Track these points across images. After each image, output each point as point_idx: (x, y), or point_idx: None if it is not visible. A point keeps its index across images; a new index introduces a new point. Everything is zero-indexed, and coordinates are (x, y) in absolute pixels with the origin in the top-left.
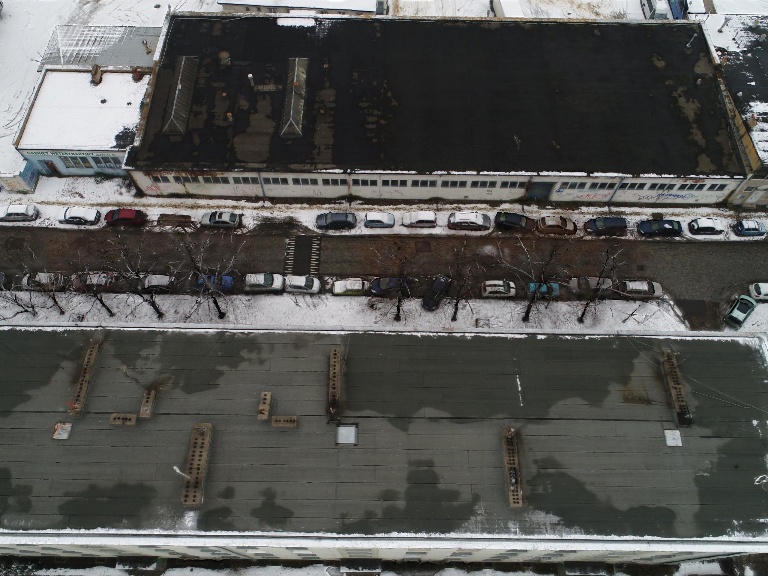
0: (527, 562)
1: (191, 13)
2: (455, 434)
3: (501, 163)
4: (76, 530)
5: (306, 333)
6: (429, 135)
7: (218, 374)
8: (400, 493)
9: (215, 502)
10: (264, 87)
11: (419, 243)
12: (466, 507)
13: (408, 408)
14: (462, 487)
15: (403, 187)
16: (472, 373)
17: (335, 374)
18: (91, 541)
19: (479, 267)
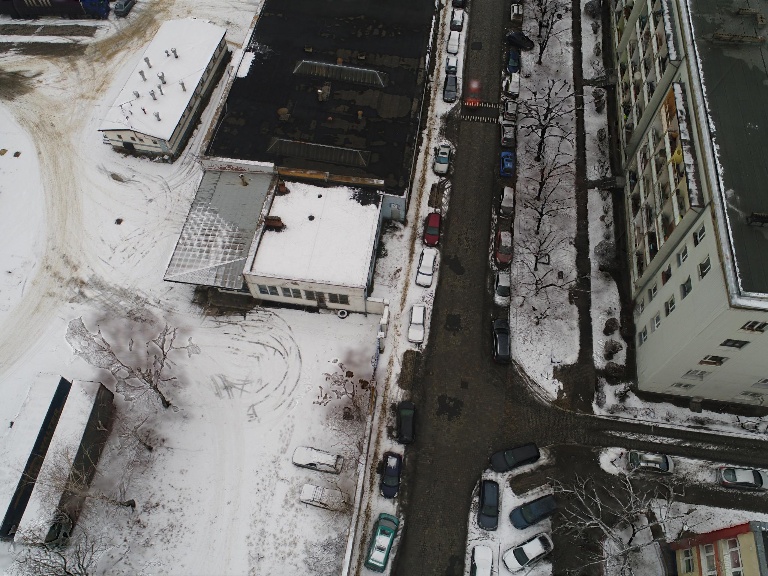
0: None
1: (207, 139)
2: None
3: None
4: None
5: None
6: (399, 4)
7: None
8: None
9: None
10: (324, 93)
11: (473, 48)
12: None
13: None
14: None
15: None
16: None
17: None
18: None
19: (496, 21)
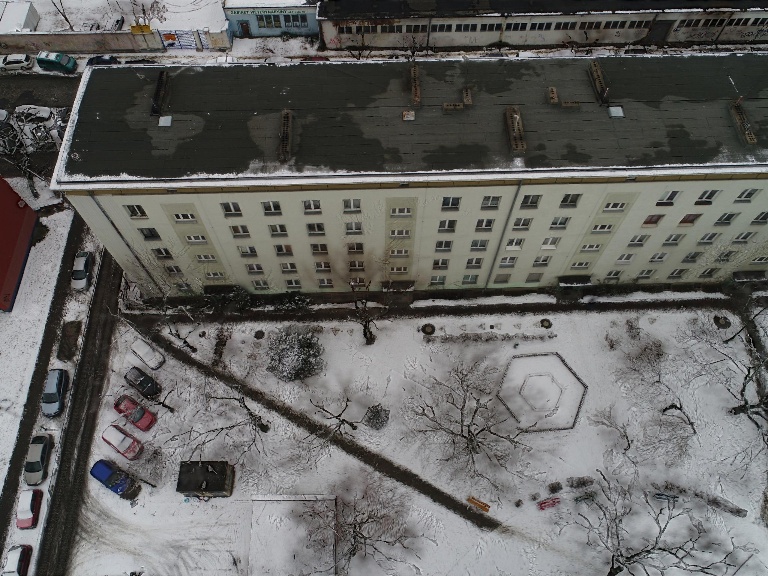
0: (697, 285)
1: None
2: (694, 109)
3: (631, 4)
4: (439, 171)
5: (565, 58)
6: None
7: (509, 83)
8: (664, 143)
9: (533, 152)
10: None
11: None
12: (714, 149)
13: (656, 96)
14: (708, 138)
15: (547, 31)
16: (695, 76)
17: (599, 76)
18: (451, 178)
19: None
